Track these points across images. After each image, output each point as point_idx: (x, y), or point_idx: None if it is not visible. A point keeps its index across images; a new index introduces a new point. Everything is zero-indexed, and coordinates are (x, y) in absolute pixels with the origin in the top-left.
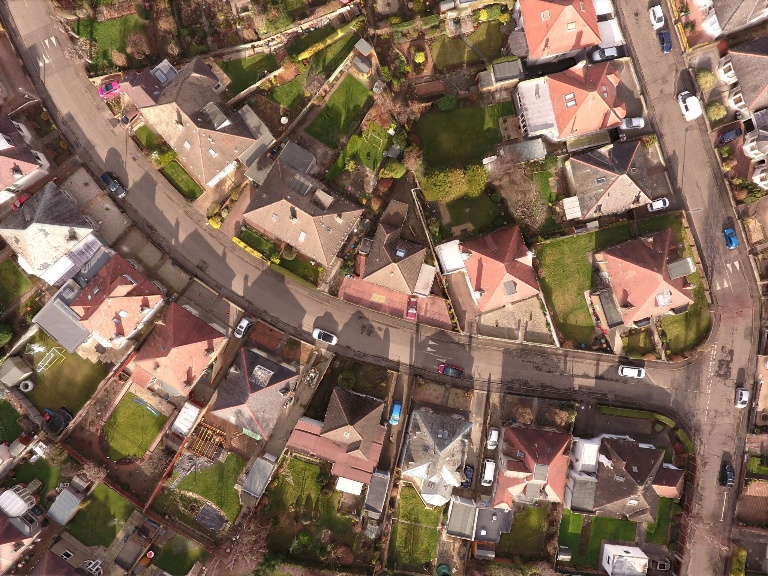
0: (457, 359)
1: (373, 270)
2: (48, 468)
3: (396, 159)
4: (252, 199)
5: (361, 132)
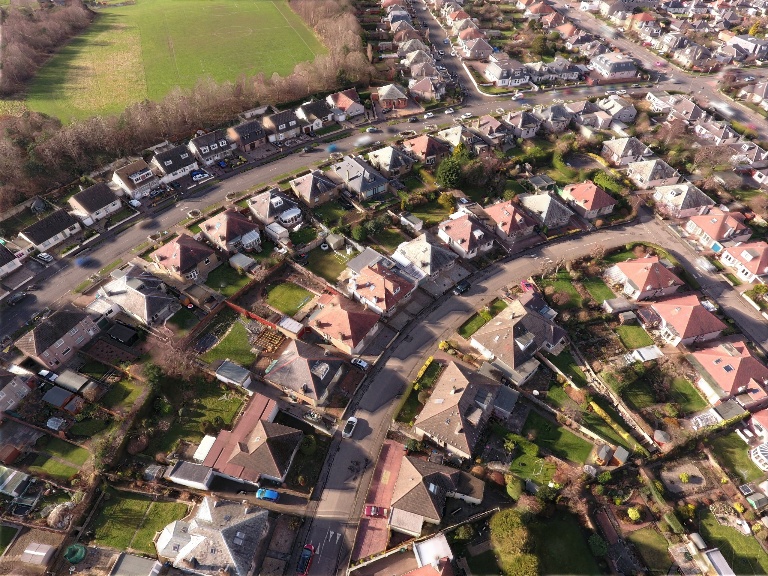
0: (318, 568)
1: (414, 463)
2: (268, 256)
3: (525, 488)
4: (466, 367)
5: (543, 457)
